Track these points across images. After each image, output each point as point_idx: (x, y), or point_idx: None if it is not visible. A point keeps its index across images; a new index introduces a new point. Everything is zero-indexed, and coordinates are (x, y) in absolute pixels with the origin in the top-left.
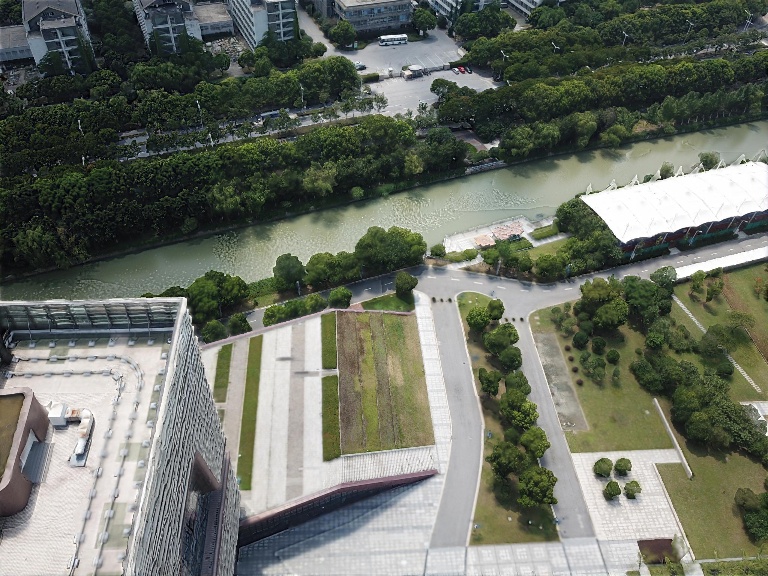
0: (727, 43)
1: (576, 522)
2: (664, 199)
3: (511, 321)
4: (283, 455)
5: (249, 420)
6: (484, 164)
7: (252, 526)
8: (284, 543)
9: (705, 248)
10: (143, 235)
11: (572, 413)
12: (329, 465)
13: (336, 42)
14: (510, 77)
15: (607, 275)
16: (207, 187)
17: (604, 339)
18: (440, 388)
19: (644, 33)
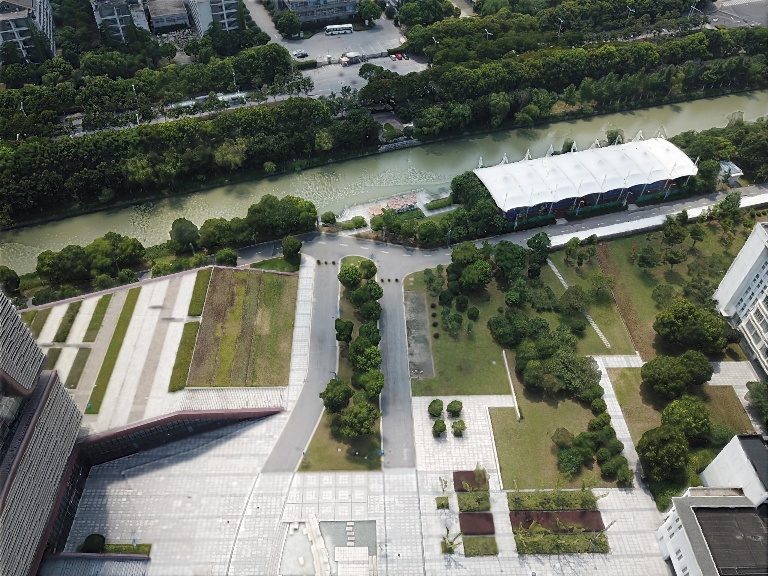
0: (666, 28)
1: (401, 455)
2: (552, 171)
3: (386, 282)
4: (134, 386)
5: (111, 357)
6: (398, 142)
7: (97, 445)
8: (132, 464)
9: (593, 219)
10: (66, 204)
11: (423, 362)
12: (172, 395)
13: (284, 32)
14: (438, 62)
15: (489, 242)
16: (123, 160)
17: (470, 298)
18: (305, 338)
19: (584, 20)
